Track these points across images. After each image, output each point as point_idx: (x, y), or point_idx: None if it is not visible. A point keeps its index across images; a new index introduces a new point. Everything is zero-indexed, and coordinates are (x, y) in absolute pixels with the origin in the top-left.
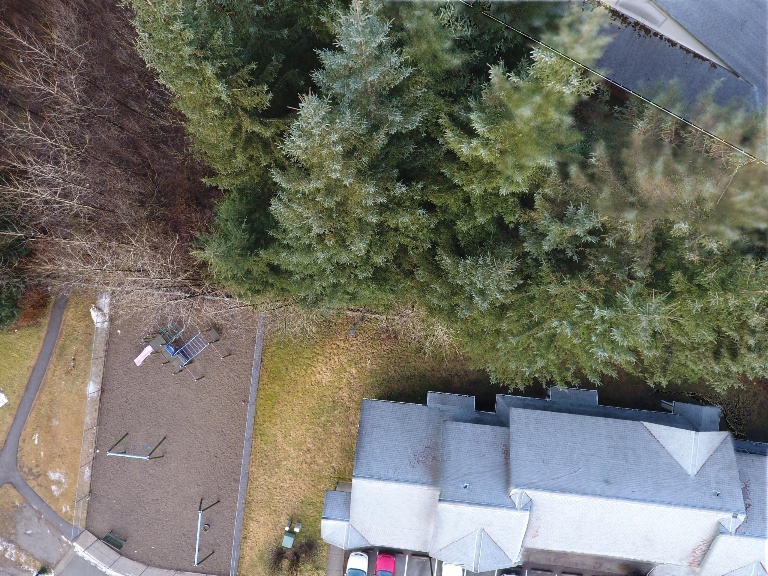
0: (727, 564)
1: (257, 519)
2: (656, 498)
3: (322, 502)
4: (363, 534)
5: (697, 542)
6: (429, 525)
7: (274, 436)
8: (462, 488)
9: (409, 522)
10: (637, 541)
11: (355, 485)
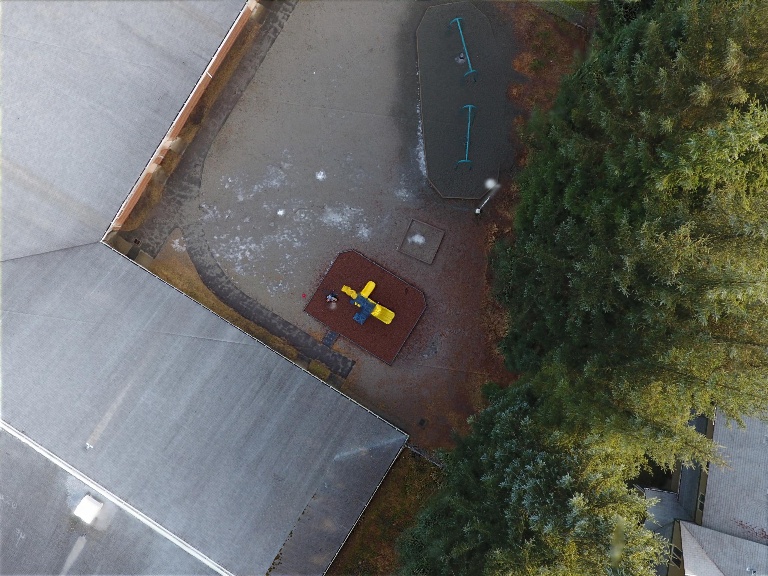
0: None
1: None
2: None
3: None
4: None
5: None
6: None
7: None
8: None
9: None
10: None
11: None
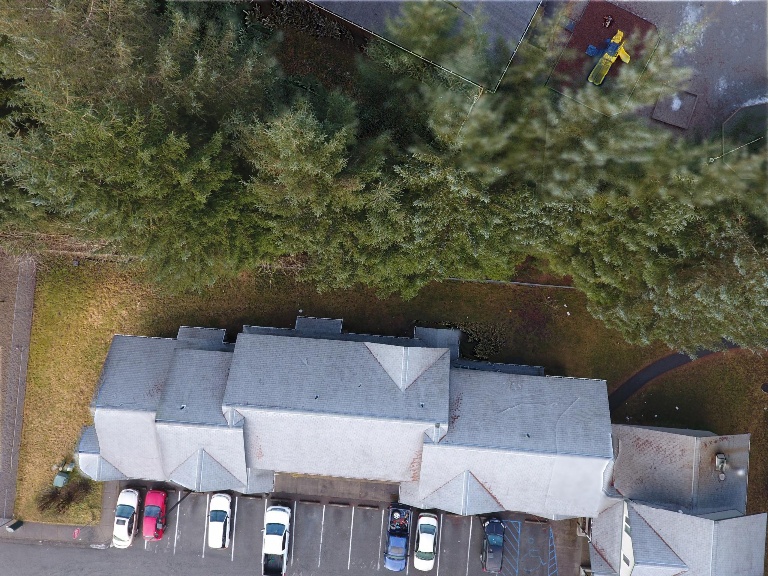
0: (440, 475)
1: (33, 461)
2: (363, 411)
3: (81, 438)
4: (117, 466)
5: (411, 455)
6: (158, 449)
7: (48, 379)
8: (179, 409)
9: (154, 451)
10: (357, 457)
11: (95, 415)
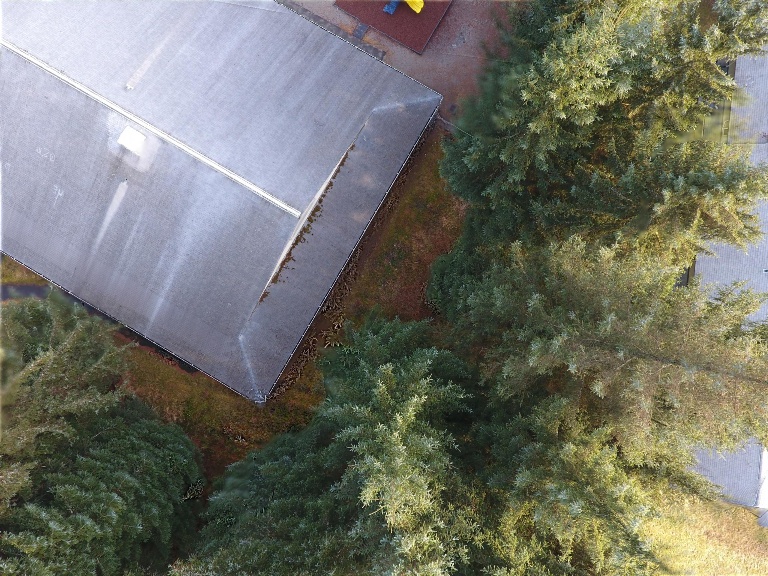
0: None
1: None
2: None
3: None
4: None
5: None
6: None
7: (694, 569)
8: None
9: None
10: None
11: (764, 506)
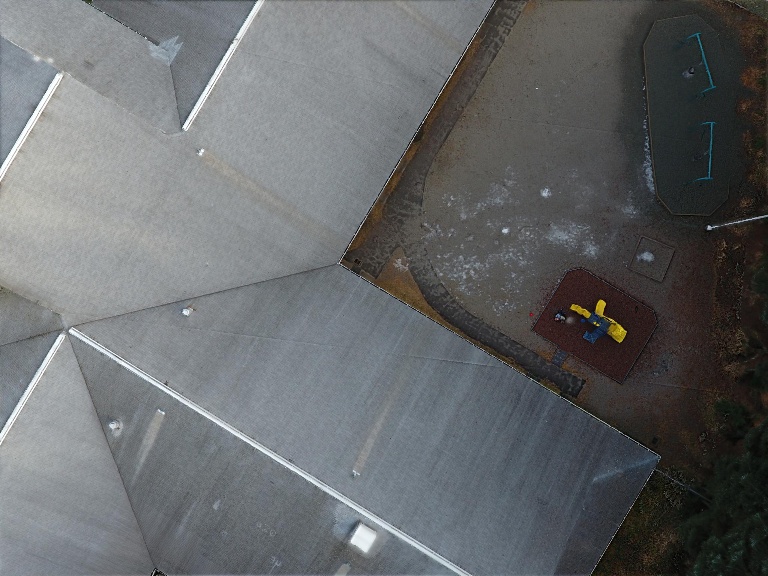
0: None
1: None
2: None
3: None
4: None
5: None
6: None
7: None
8: None
9: None
10: None
11: None
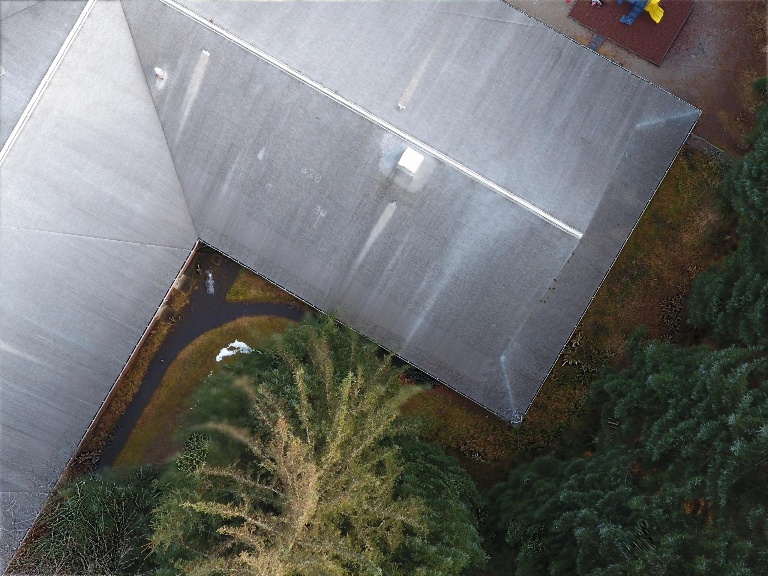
0: None
1: None
2: None
3: None
4: None
5: None
6: None
7: None
8: None
9: None
10: None
11: None
